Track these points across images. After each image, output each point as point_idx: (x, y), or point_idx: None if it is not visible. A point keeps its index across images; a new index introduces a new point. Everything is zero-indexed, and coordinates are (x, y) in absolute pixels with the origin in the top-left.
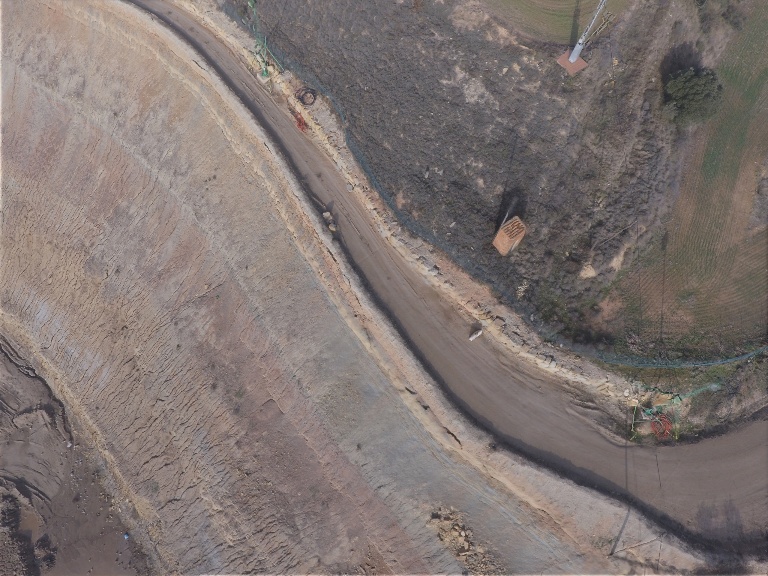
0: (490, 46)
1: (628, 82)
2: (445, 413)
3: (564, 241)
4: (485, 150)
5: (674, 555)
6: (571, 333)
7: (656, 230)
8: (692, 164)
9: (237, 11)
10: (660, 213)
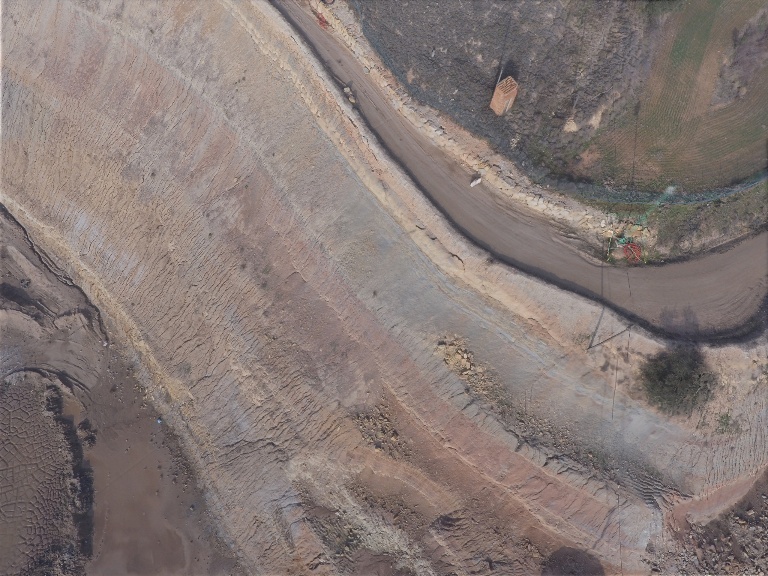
0: None
1: None
2: (450, 237)
3: (550, 103)
4: (483, 31)
5: (640, 343)
6: (556, 176)
7: (630, 99)
8: (662, 51)
9: None
10: (633, 84)
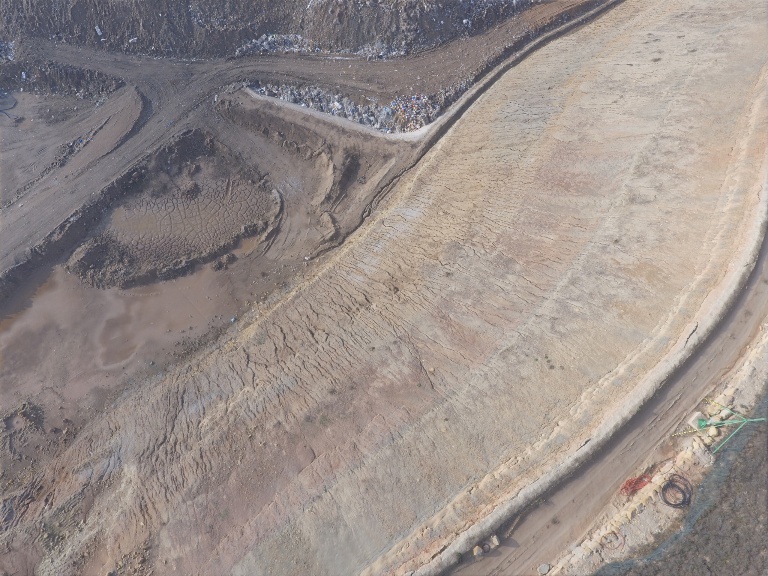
0: None
1: None
2: None
3: None
4: None
5: None
6: None
7: None
8: None
9: None
10: None
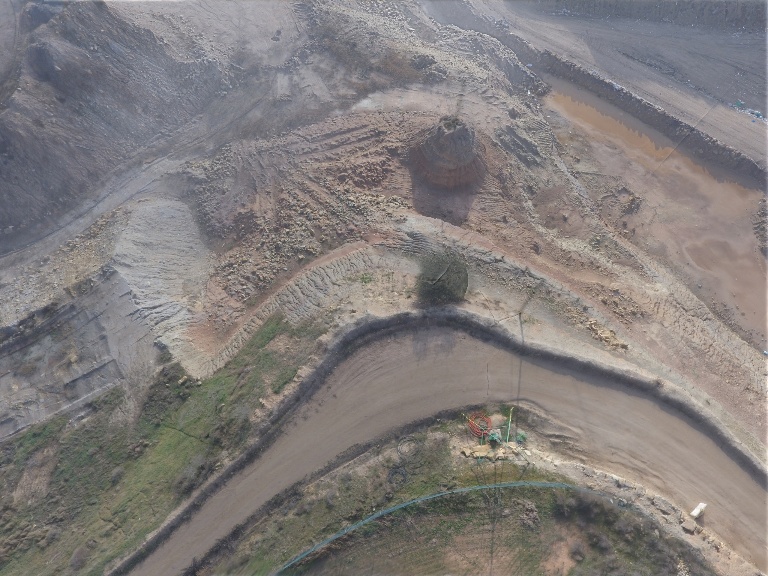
0: None
1: None
2: None
3: None
4: None
5: (481, 312)
6: (605, 518)
7: None
8: None
9: None
10: None
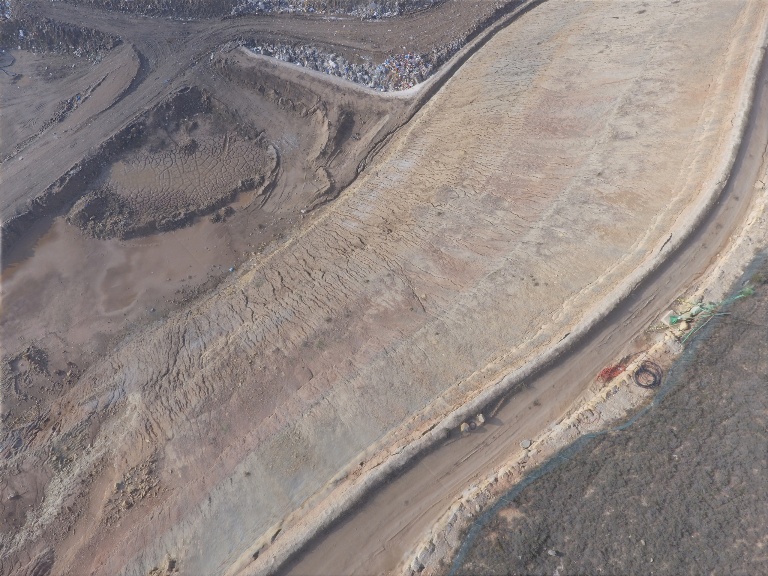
0: None
1: None
2: None
3: None
4: None
5: None
6: None
7: None
8: None
9: (760, 272)
10: None
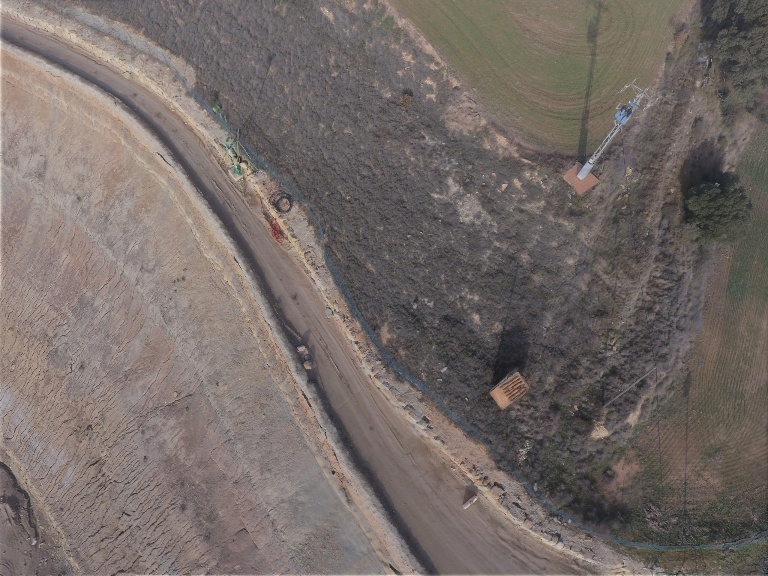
0: (487, 156)
1: (644, 196)
2: None
3: (572, 393)
4: (481, 280)
5: None
6: (581, 506)
7: (677, 372)
8: (716, 285)
9: (207, 98)
10: (682, 352)
